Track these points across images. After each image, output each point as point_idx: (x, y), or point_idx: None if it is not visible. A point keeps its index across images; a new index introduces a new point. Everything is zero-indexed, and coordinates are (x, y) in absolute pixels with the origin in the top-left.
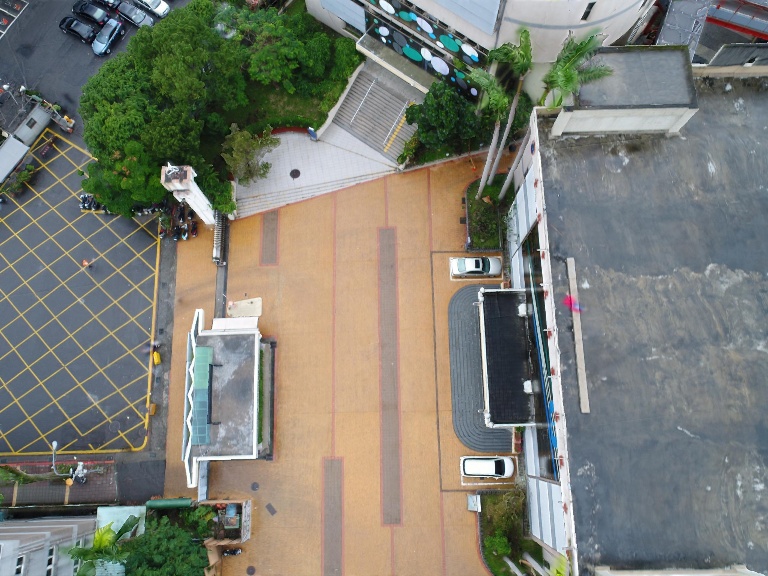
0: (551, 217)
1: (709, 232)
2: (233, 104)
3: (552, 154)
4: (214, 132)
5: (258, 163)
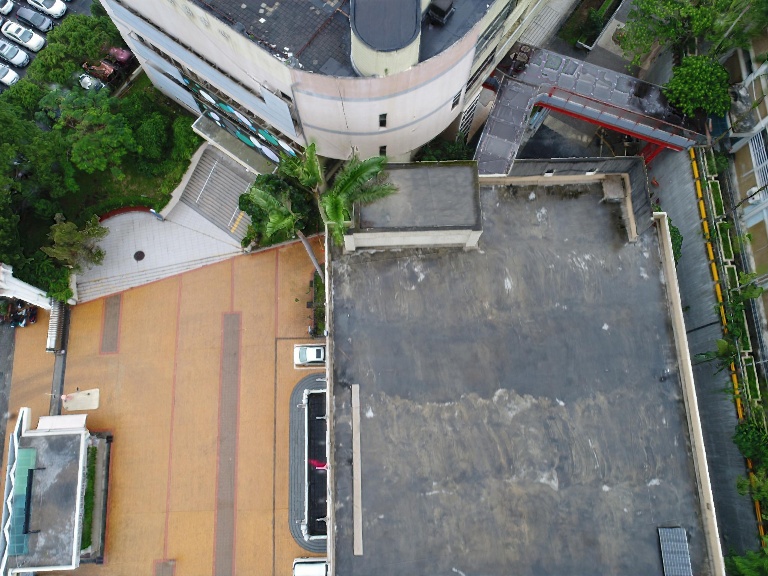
0: (340, 339)
1: (500, 354)
2: (60, 191)
3: (346, 270)
4: (46, 217)
5: (91, 250)
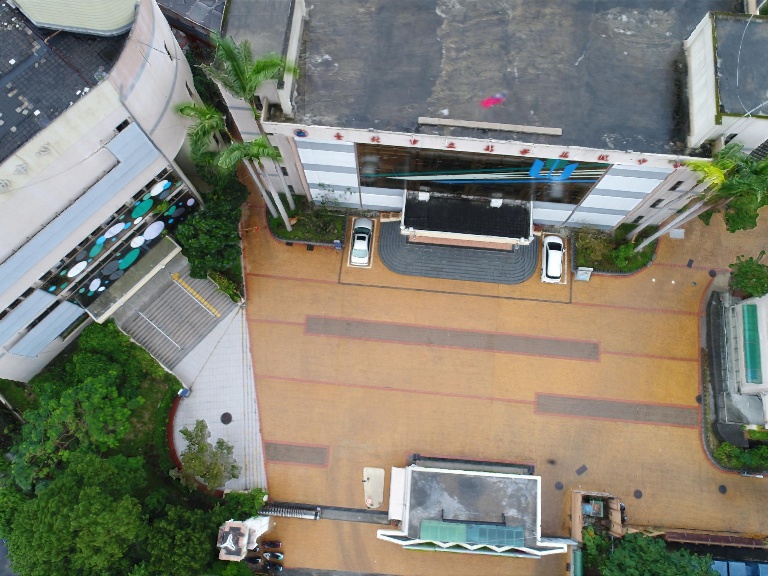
0: None
1: (406, 6)
2: (142, 474)
3: (310, 118)
4: None
5: None
